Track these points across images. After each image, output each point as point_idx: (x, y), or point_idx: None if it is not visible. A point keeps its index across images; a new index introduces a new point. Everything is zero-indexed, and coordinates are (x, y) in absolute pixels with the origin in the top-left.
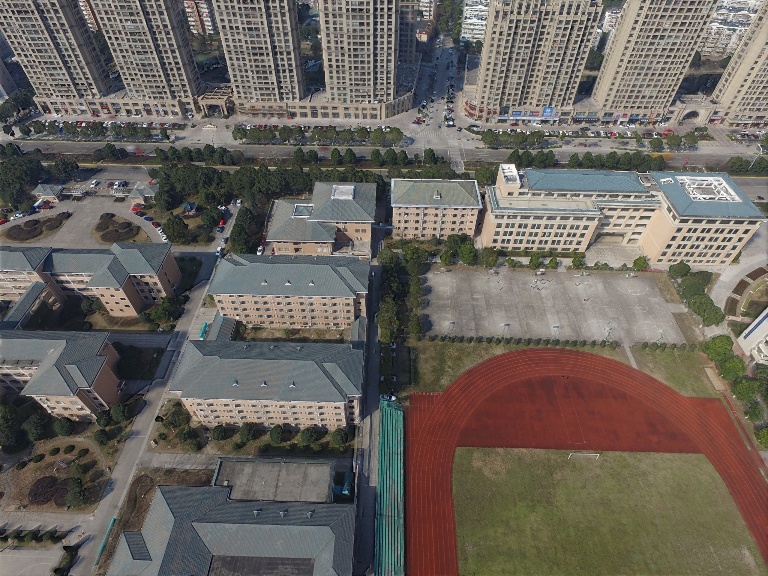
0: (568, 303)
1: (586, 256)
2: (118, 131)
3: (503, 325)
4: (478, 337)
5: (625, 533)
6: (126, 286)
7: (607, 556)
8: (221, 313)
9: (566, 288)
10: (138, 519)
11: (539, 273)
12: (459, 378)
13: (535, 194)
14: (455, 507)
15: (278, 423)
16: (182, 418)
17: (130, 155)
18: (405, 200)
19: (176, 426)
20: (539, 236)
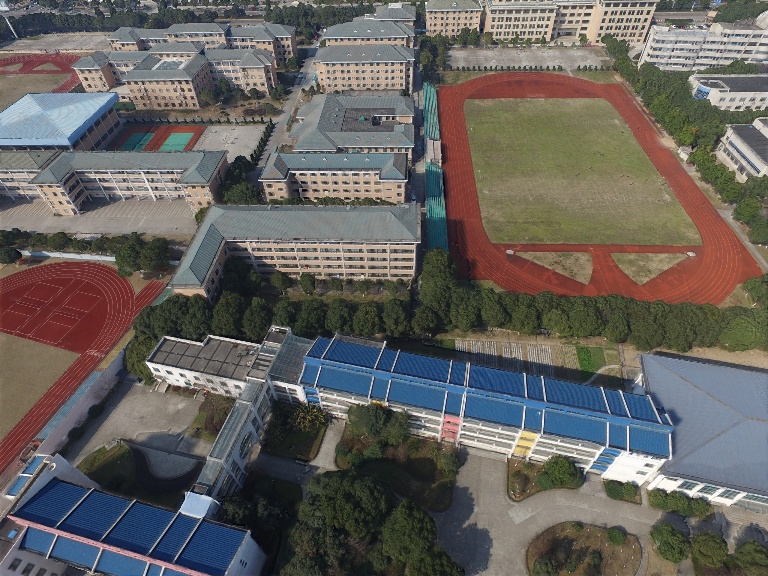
0: (536, 58)
1: (551, 43)
2: (237, 1)
3: (494, 61)
4: (479, 66)
5: (554, 117)
6: (273, 43)
7: (543, 122)
8: None
9: (535, 54)
10: None
11: None
12: (468, 81)
13: (516, 1)
14: (465, 113)
15: (368, 87)
16: (317, 84)
17: (247, 15)
18: (434, 7)
19: (312, 95)
20: (519, 28)
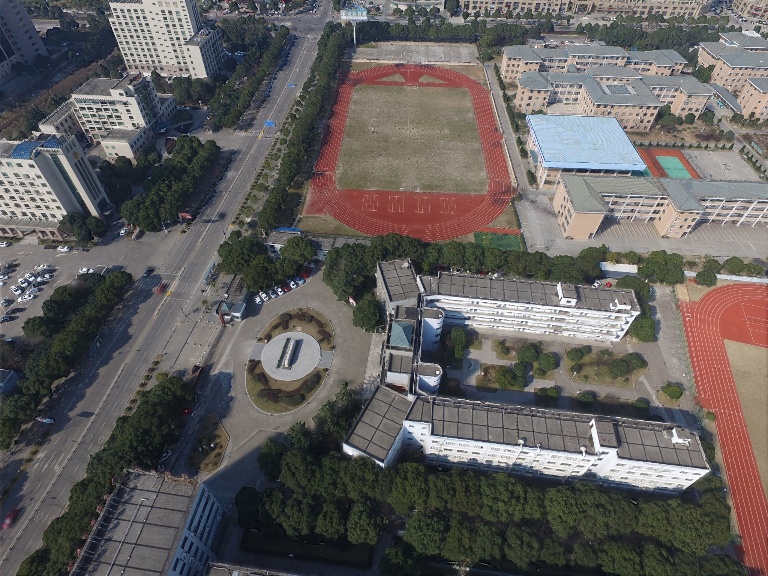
0: None
1: None
2: (541, 16)
3: None
4: None
5: None
6: None
7: None
8: (723, 84)
9: None
10: (759, 145)
11: None
12: None
13: None
14: None
15: None
16: None
17: None
18: None
19: None
20: None
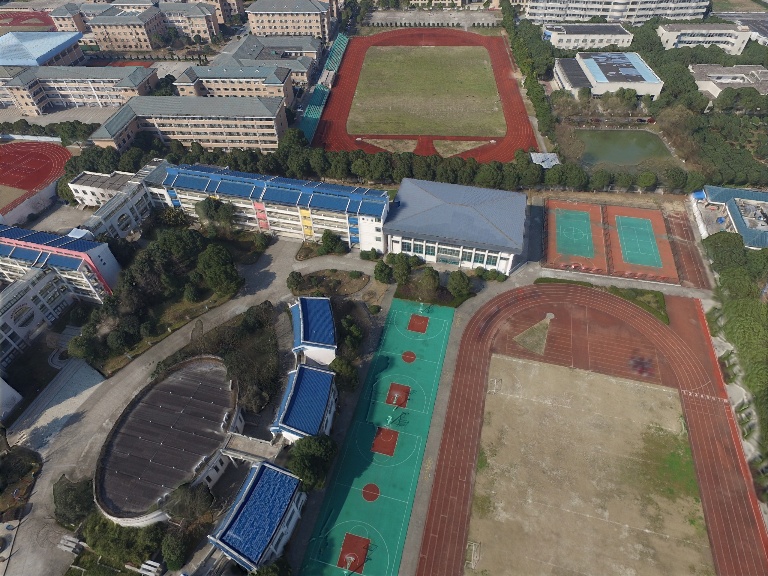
0: (443, 18)
1: (461, 8)
2: None
3: (404, 19)
4: None
5: (436, 58)
6: (220, 2)
7: (425, 61)
8: None
9: (444, 15)
10: None
11: (431, 8)
12: None
13: None
14: (366, 55)
15: None
16: (249, 32)
17: None
18: None
19: None
20: None
